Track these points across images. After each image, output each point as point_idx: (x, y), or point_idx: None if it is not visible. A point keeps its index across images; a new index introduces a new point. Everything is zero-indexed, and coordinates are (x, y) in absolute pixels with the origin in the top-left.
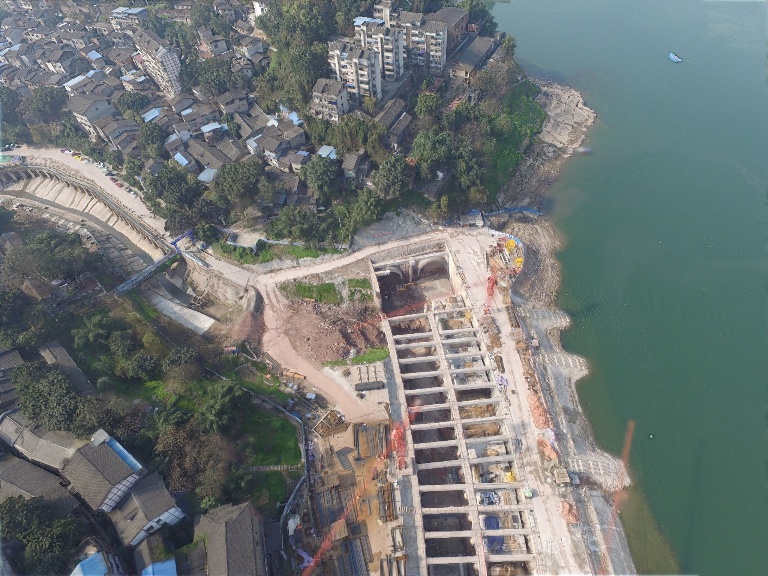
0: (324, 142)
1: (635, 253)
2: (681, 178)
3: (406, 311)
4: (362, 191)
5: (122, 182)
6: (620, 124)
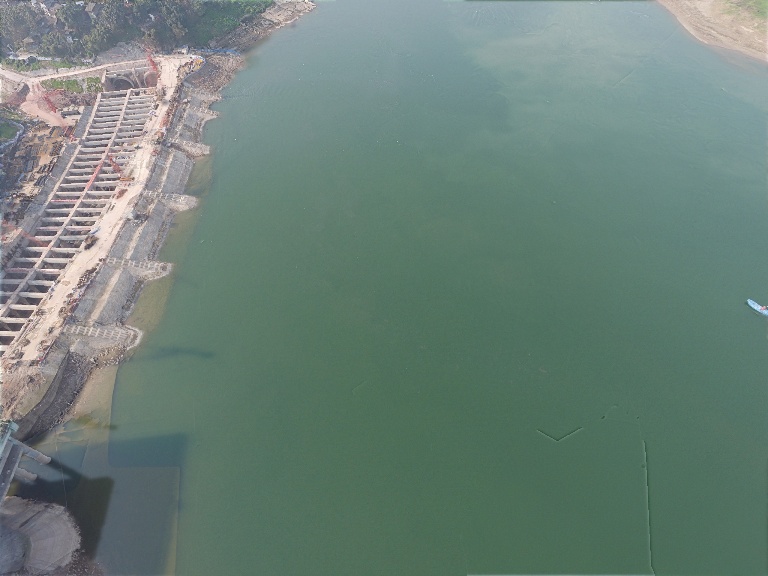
0: (82, 0)
1: (285, 70)
2: (343, 36)
3: None
4: None
5: None
6: (328, 11)
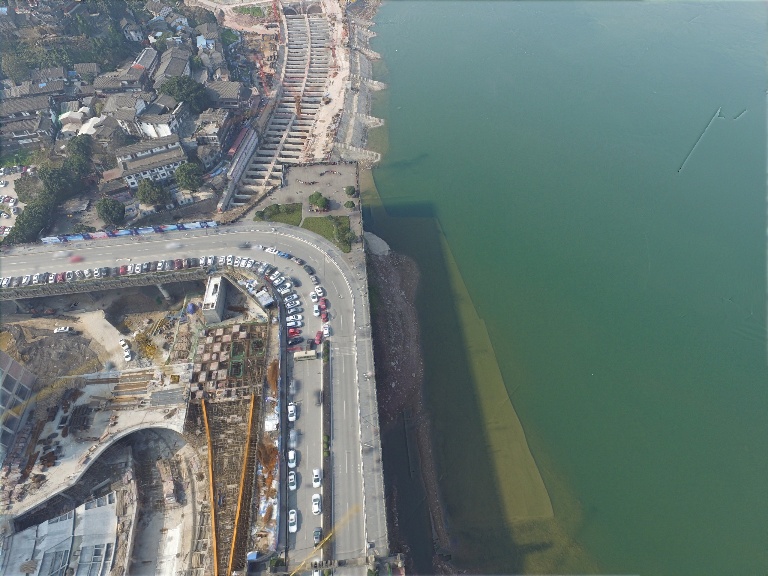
0: None
1: (418, 7)
2: None
3: None
4: None
5: None
6: None
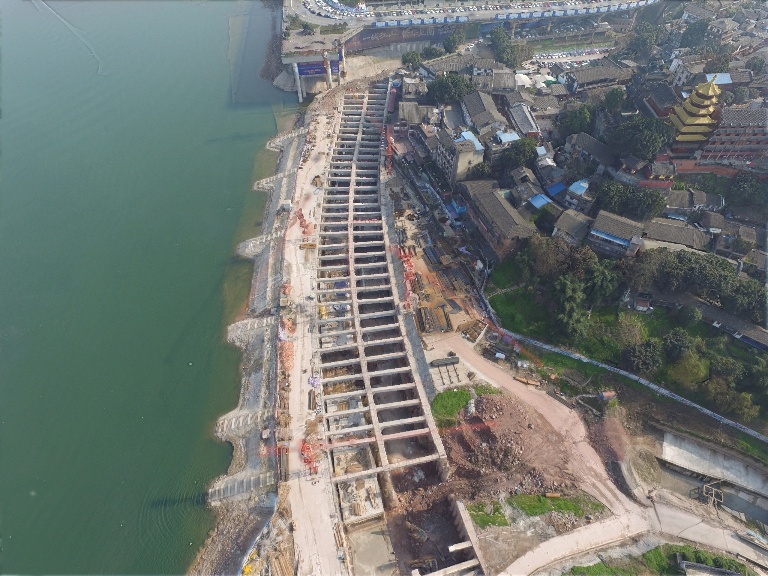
0: None
1: None
2: None
3: (420, 519)
4: None
5: None
6: None
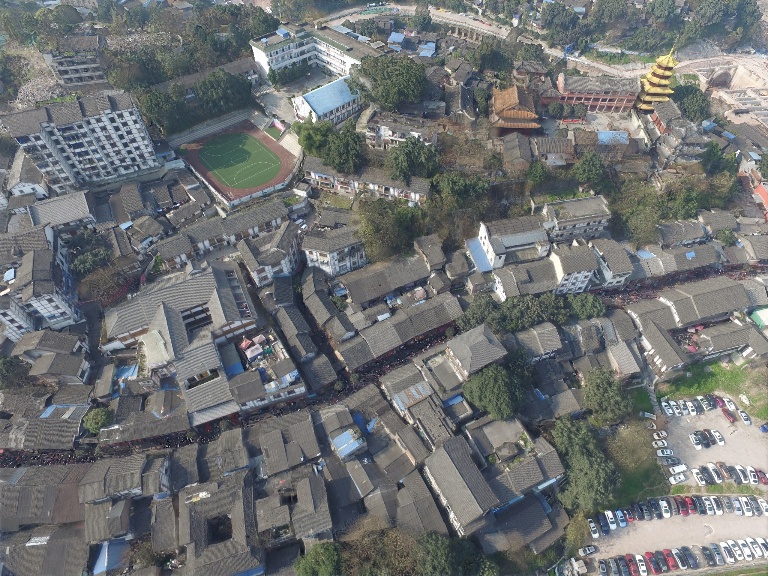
0: None
1: None
2: None
3: None
4: (688, 21)
5: (491, 23)
6: None
